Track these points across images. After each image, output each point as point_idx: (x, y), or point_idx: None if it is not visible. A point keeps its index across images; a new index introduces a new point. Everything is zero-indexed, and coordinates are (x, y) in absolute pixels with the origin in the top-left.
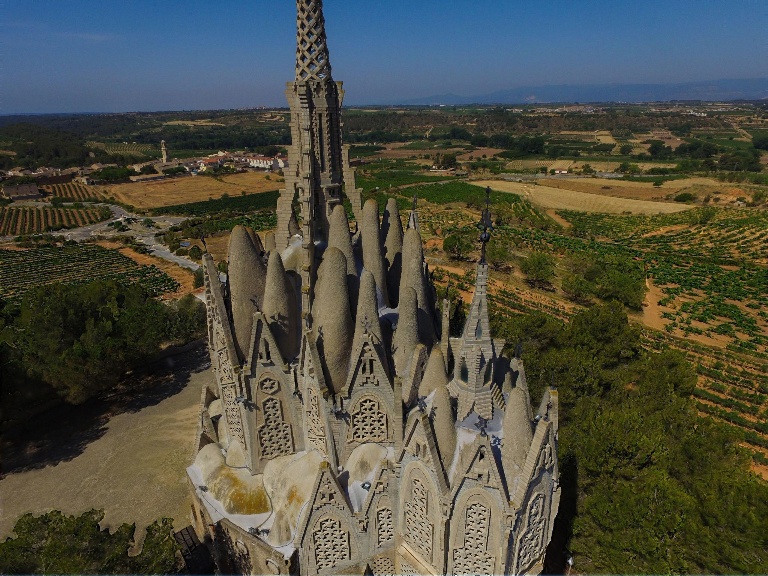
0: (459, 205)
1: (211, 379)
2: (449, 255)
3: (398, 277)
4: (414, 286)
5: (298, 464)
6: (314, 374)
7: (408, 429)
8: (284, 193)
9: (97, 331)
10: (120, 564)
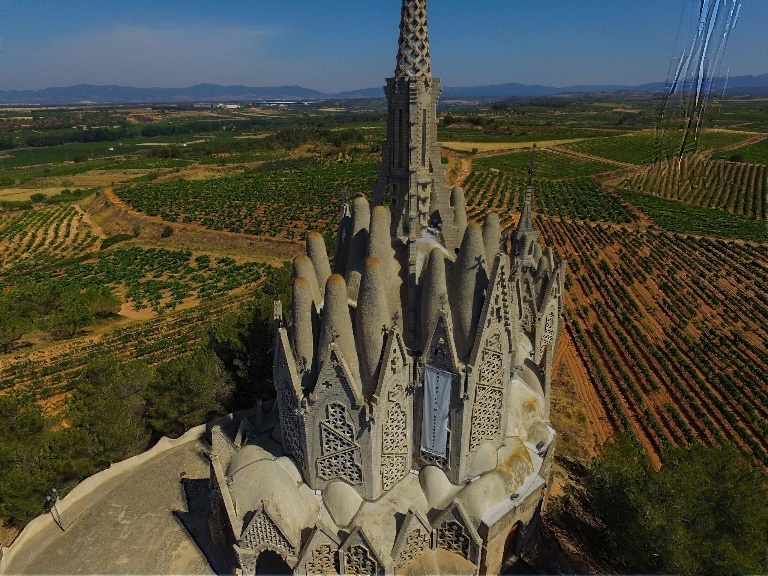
0: None
1: None
2: None
3: None
4: None
5: (513, 393)
6: None
7: None
8: (416, 194)
9: None
10: None
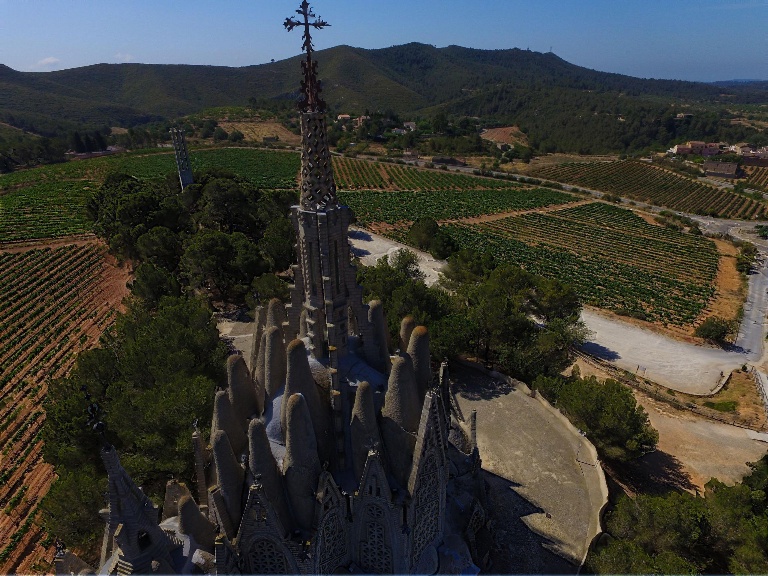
0: None
1: None
2: None
3: (353, 439)
4: None
5: None
6: None
7: None
8: None
9: (413, 317)
10: (185, 429)
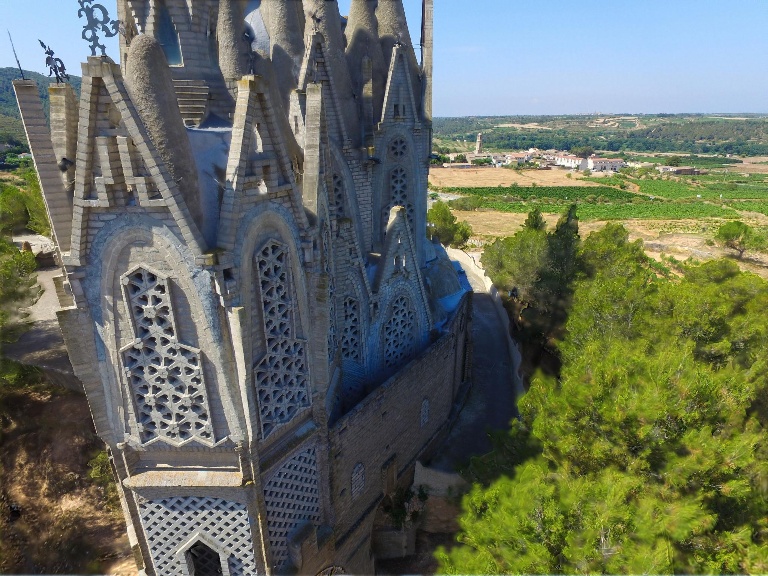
0: None
1: None
2: (722, 248)
3: (356, 64)
4: (270, 4)
5: None
6: None
7: None
8: None
9: None
10: None
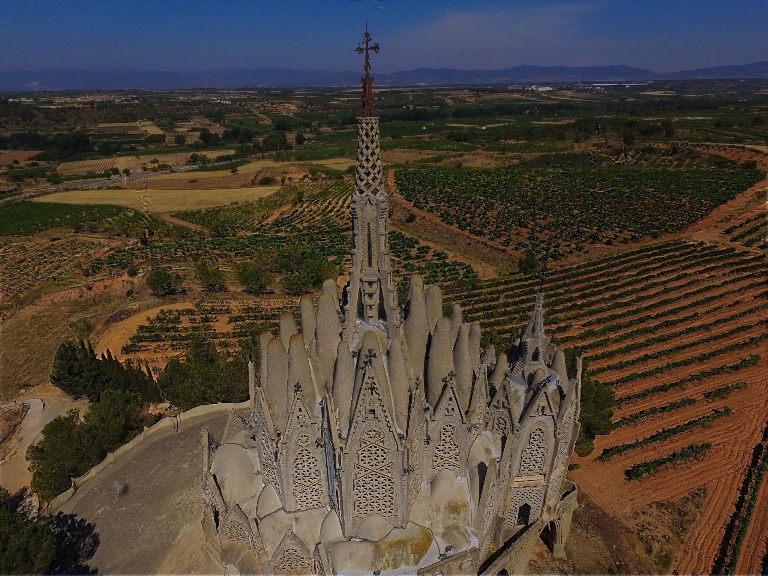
0: (61, 232)
1: (125, 547)
2: (161, 293)
3: None
4: (460, 322)
5: (442, 488)
6: (455, 411)
7: (536, 402)
8: (353, 290)
9: None
10: None
